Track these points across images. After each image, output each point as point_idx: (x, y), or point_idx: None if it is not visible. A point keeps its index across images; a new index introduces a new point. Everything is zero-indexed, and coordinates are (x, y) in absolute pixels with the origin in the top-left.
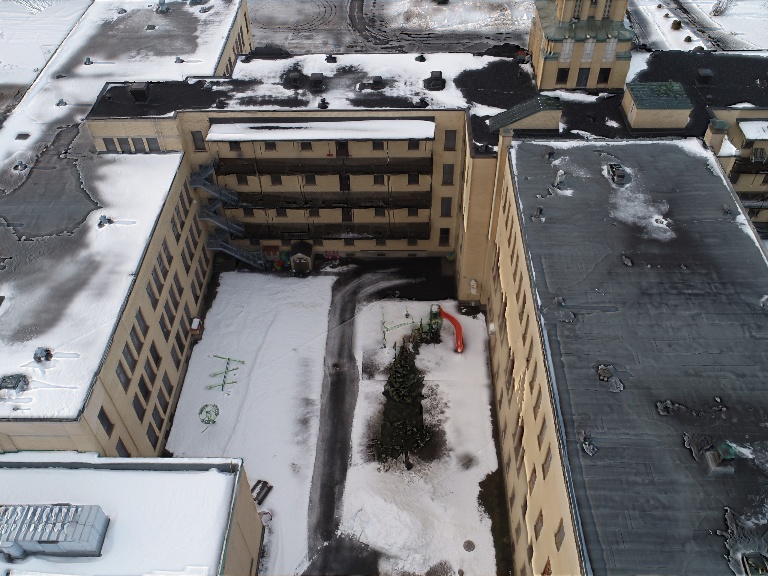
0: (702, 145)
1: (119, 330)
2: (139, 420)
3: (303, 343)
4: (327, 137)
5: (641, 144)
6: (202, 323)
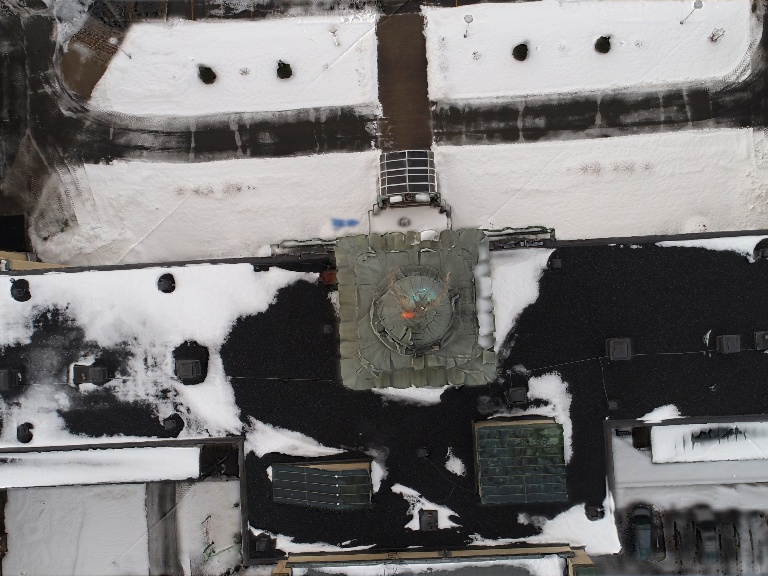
0: (563, 571)
1: None
2: None
3: (122, 552)
4: (46, 483)
5: (477, 567)
6: (2, 531)
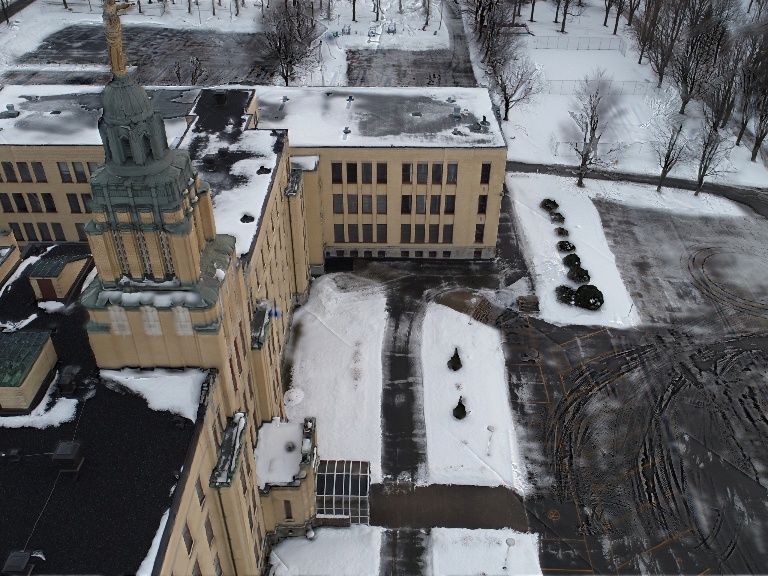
0: None
1: (5, 150)
2: (4, 209)
3: None
4: None
5: None
6: None
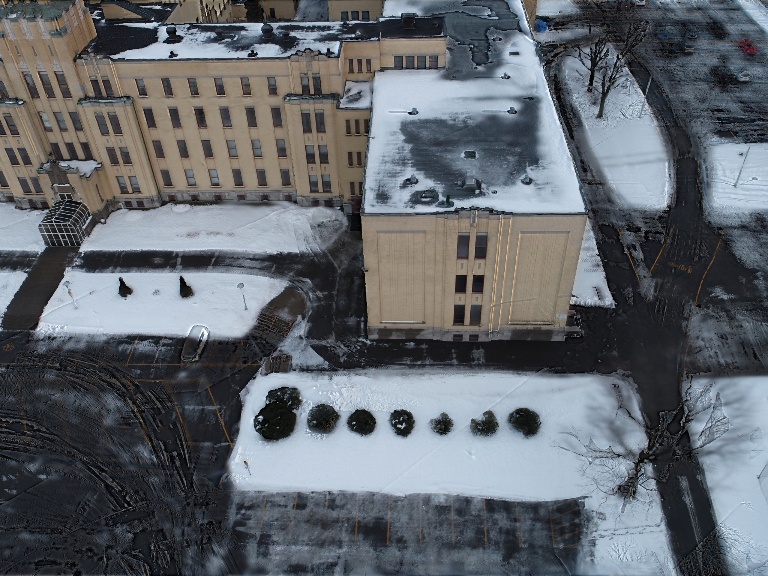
0: None
1: None
2: None
3: None
4: None
5: None
6: None
